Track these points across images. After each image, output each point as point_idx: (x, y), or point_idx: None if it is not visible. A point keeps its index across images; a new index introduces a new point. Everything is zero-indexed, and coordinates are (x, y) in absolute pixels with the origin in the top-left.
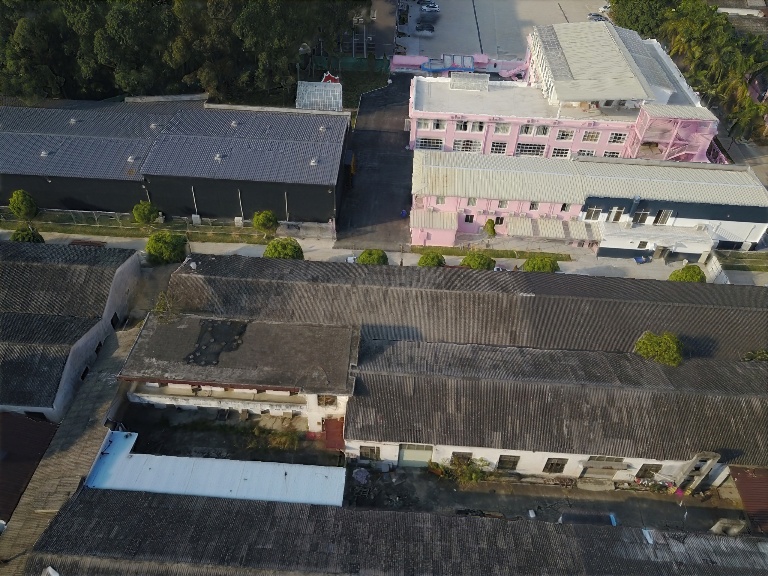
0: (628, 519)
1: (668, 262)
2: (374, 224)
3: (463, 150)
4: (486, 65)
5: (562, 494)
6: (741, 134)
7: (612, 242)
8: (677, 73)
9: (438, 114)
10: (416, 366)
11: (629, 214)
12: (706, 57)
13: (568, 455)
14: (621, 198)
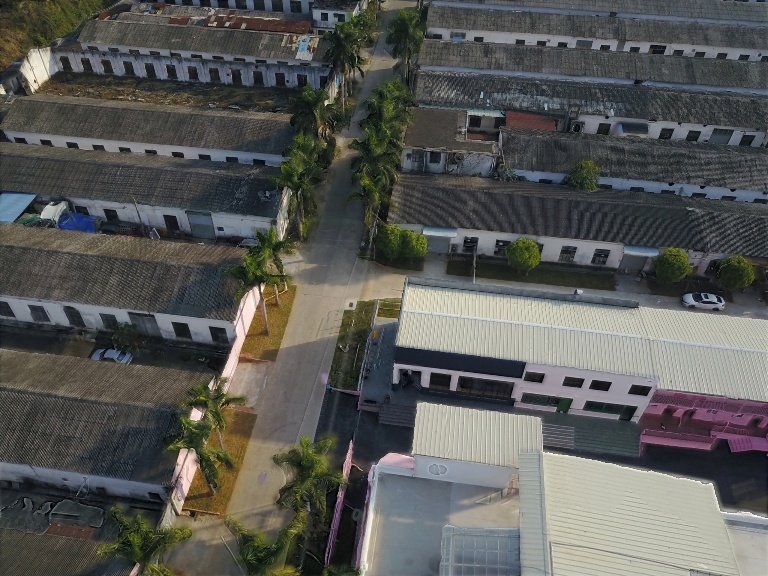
0: None
1: None
2: None
3: None
4: None
5: None
6: None
7: None
8: None
9: None
10: (763, 163)
11: None
12: None
13: None
14: (597, 298)
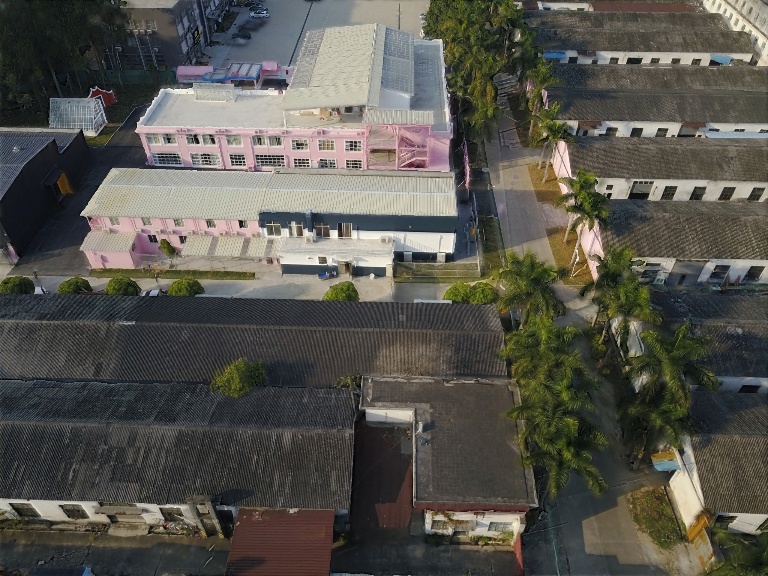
0: (140, 568)
1: (356, 277)
2: (64, 247)
3: (204, 164)
4: (277, 72)
5: (87, 542)
6: (477, 137)
7: (290, 258)
8: (443, 74)
9: (164, 128)
10: None
11: (307, 228)
12: (465, 57)
13: (70, 502)
14: None
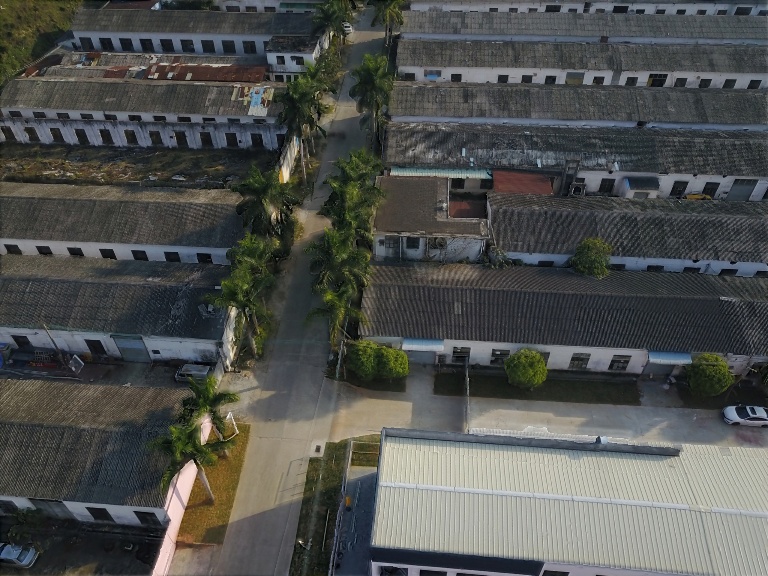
0: None
1: None
2: None
3: None
4: None
5: None
6: None
7: None
8: None
9: None
10: None
11: None
12: None
13: None
14: (626, 447)
